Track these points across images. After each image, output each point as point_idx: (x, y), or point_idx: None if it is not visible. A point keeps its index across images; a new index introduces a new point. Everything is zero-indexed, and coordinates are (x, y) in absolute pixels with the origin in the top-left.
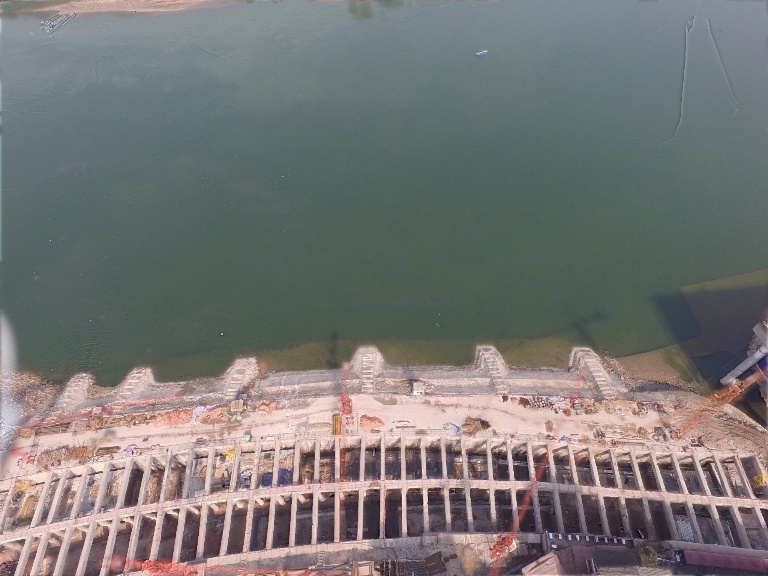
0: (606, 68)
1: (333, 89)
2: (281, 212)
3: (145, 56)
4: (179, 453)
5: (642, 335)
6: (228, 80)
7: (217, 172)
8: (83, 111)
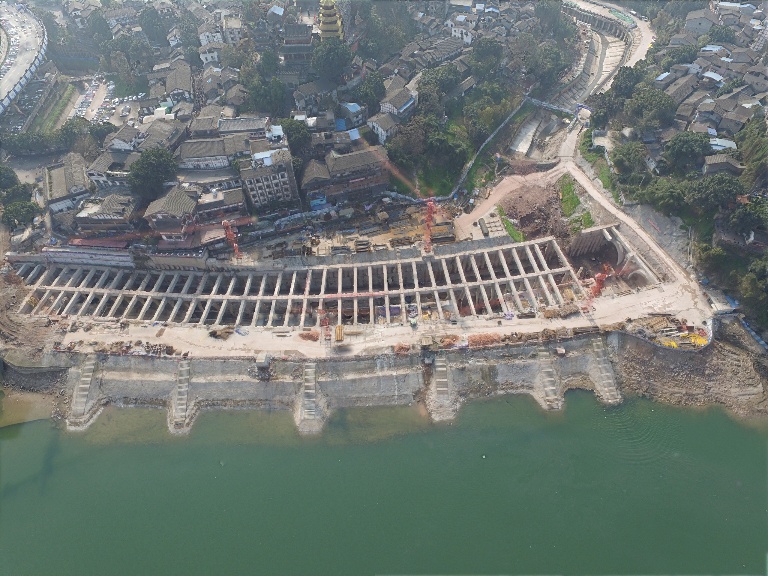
0: None
1: None
2: None
3: None
4: None
5: None
6: None
7: None
8: None
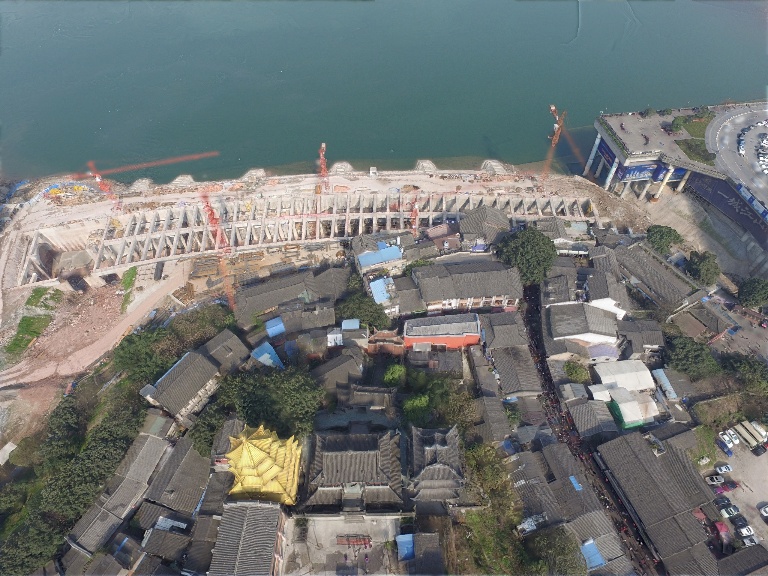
0: (542, 3)
1: (321, 19)
2: (280, 93)
3: (167, 1)
4: (215, 206)
5: (535, 154)
6: (236, 15)
7: (231, 69)
8: (123, 34)
